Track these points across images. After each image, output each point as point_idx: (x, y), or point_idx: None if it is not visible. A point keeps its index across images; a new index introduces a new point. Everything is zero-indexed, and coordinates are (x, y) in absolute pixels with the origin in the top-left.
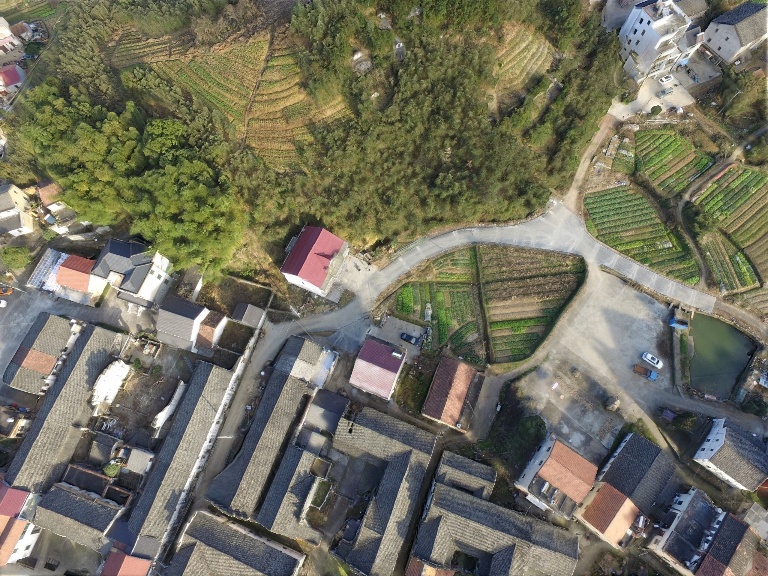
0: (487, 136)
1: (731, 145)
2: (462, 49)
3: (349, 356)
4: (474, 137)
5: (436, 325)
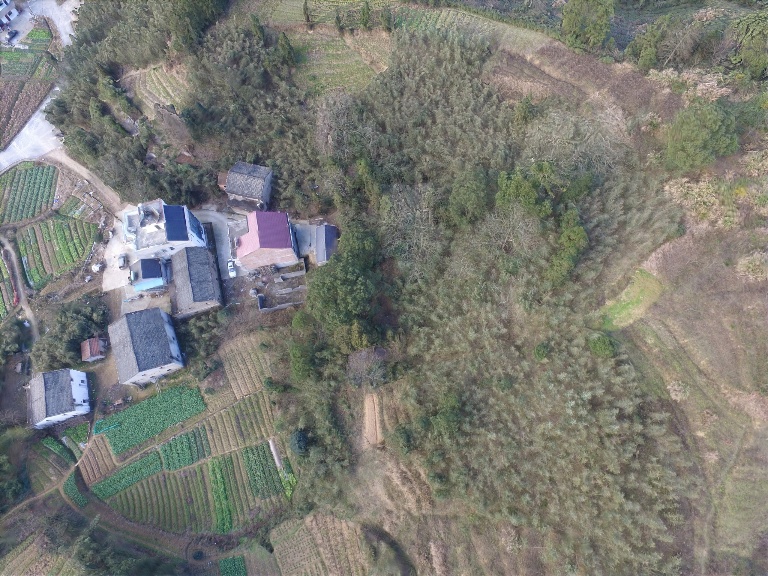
0: (96, 57)
1: (38, 308)
2: (163, 25)
3: (21, 2)
4: (101, 49)
5: (11, 50)
